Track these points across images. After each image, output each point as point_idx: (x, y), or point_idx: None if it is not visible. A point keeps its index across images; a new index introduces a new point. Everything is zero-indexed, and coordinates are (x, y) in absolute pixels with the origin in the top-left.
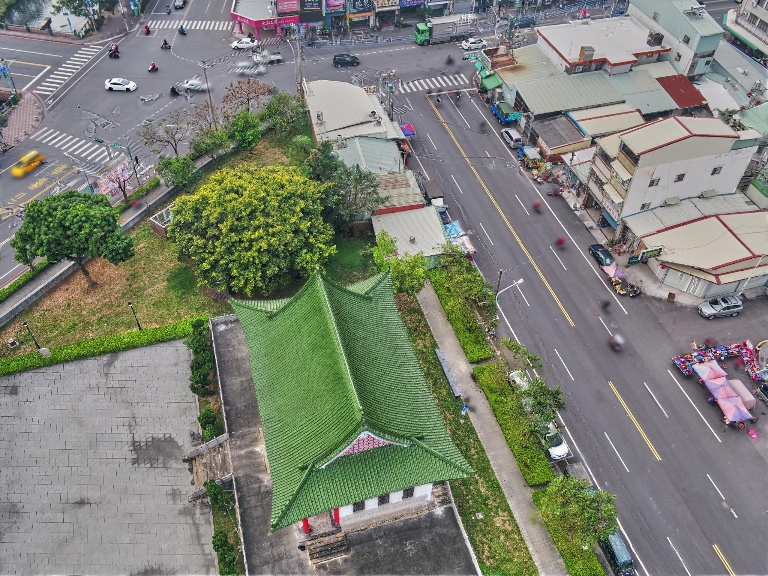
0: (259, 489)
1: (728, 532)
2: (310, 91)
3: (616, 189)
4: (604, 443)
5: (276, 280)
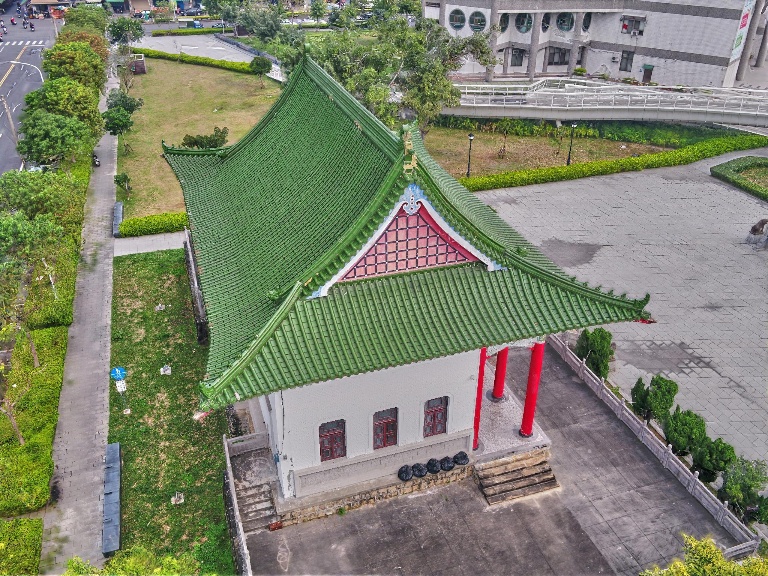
0: None
1: None
2: None
3: None
4: None
5: None
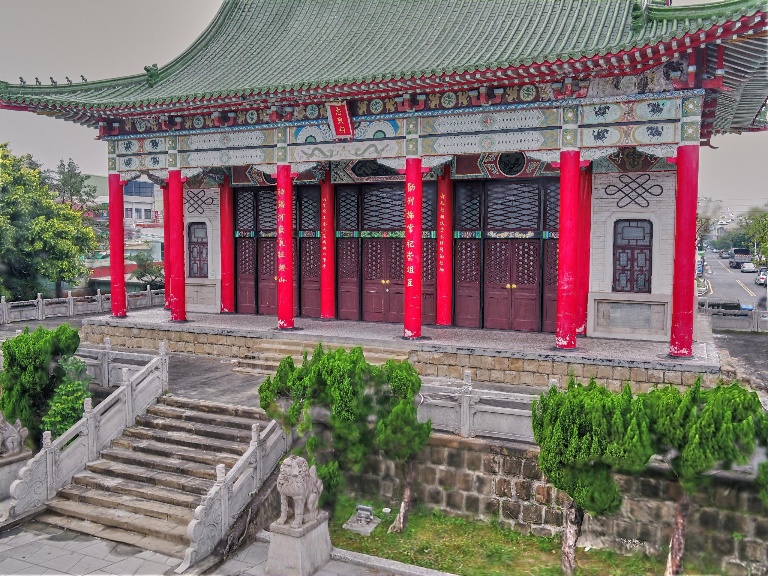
0: None
1: None
2: None
3: None
4: None
5: None
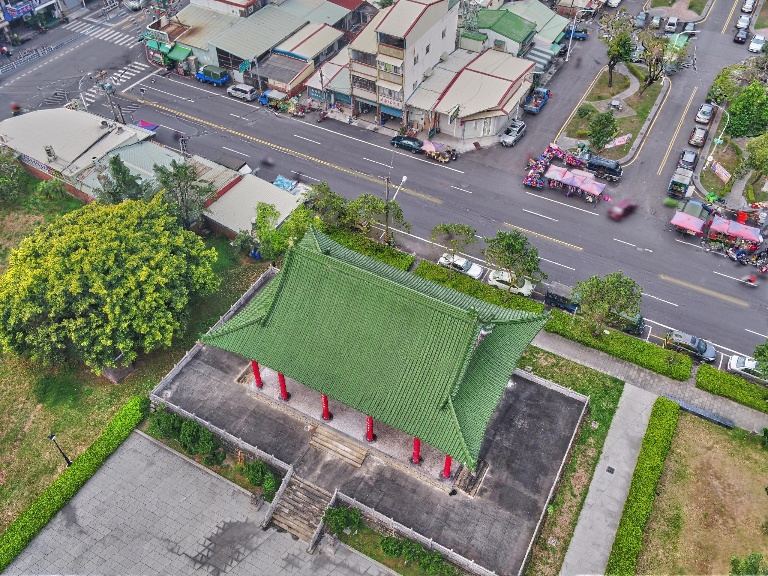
0: (368, 485)
1: (657, 263)
2: (4, 136)
3: (389, 81)
4: (543, 263)
5: (181, 315)
